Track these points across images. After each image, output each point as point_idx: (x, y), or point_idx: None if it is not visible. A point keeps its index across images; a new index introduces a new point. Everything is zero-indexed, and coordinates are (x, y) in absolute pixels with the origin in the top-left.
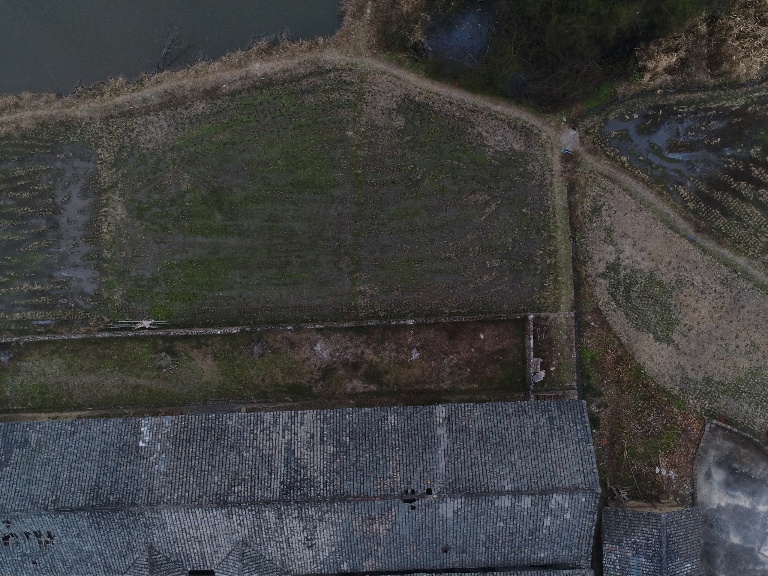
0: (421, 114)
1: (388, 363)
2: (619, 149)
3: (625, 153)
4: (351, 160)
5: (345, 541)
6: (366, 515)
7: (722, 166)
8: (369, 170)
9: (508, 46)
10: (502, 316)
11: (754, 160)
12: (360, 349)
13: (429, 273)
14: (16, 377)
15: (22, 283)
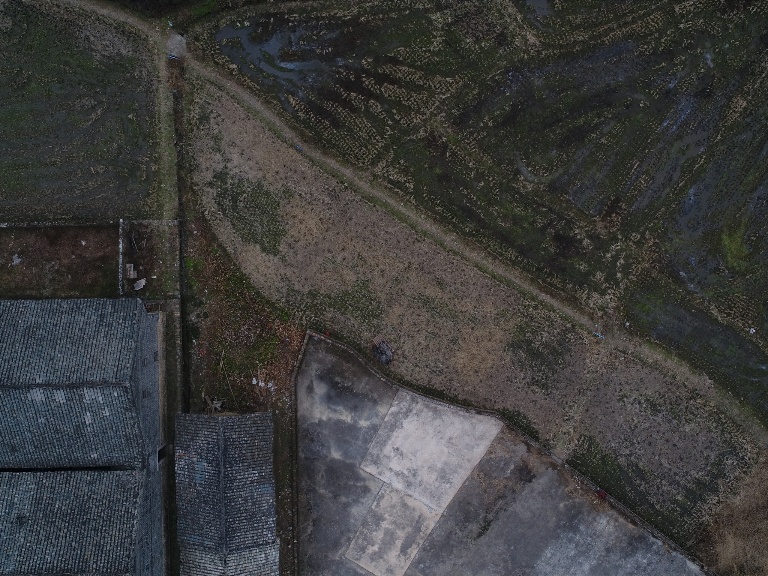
0: (28, 17)
1: None
2: (230, 57)
3: (237, 61)
4: None
5: None
6: None
7: (334, 76)
8: None
9: None
10: None
11: (366, 71)
12: None
13: (33, 178)
14: None
15: None
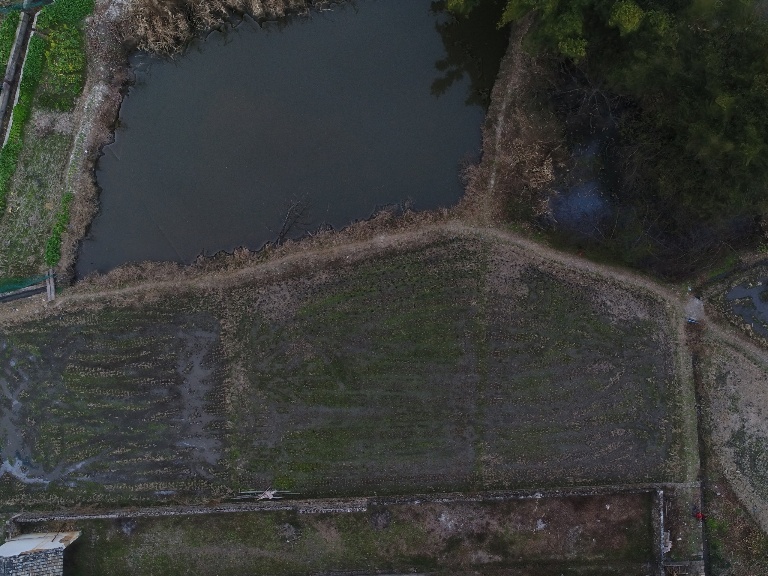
0: (544, 283)
1: (513, 534)
2: (743, 316)
3: (749, 320)
4: (475, 329)
5: None
6: None
7: None
8: (493, 340)
9: (638, 224)
10: (631, 490)
11: None
12: (485, 520)
13: (553, 442)
14: (138, 548)
15: (144, 453)
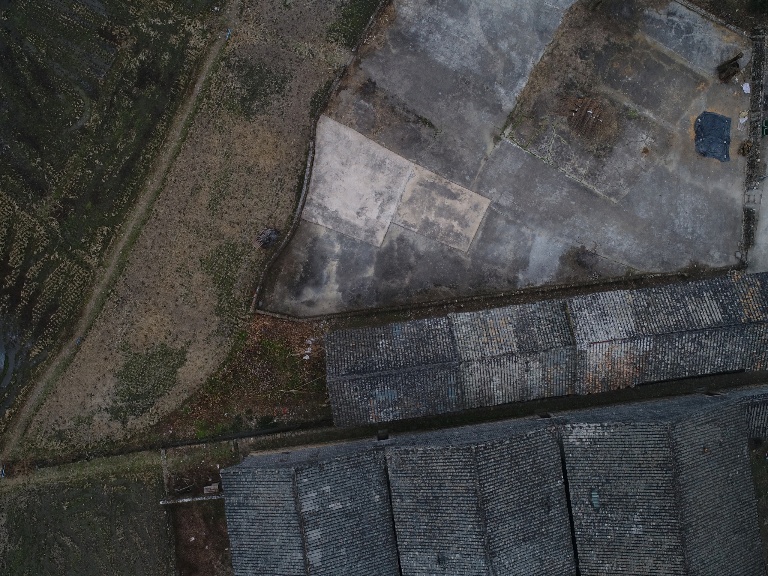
0: None
1: None
2: None
3: (3, 411)
4: None
5: None
6: None
7: (8, 315)
8: None
9: None
10: None
11: None
12: None
13: None
14: None
15: None
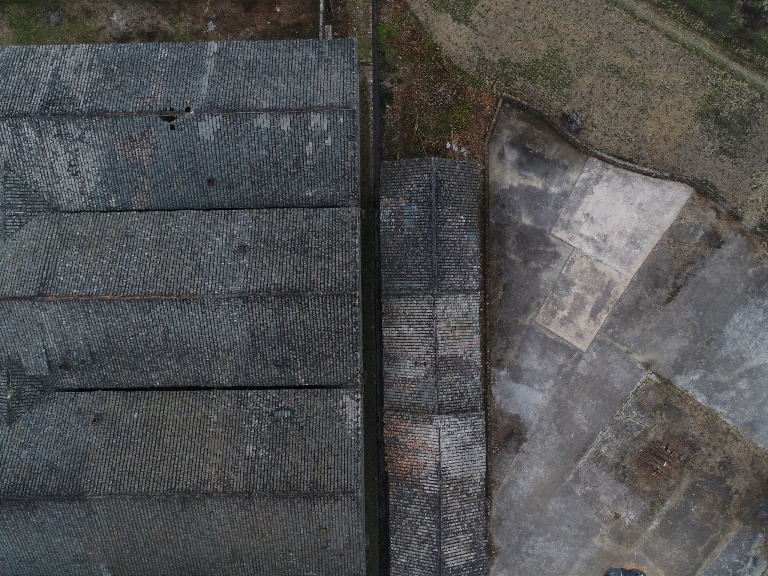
0: None
1: (184, 34)
2: None
3: None
4: None
5: (109, 169)
6: (126, 135)
7: None
8: None
9: None
10: None
11: None
12: (156, 20)
13: None
14: None
15: None
